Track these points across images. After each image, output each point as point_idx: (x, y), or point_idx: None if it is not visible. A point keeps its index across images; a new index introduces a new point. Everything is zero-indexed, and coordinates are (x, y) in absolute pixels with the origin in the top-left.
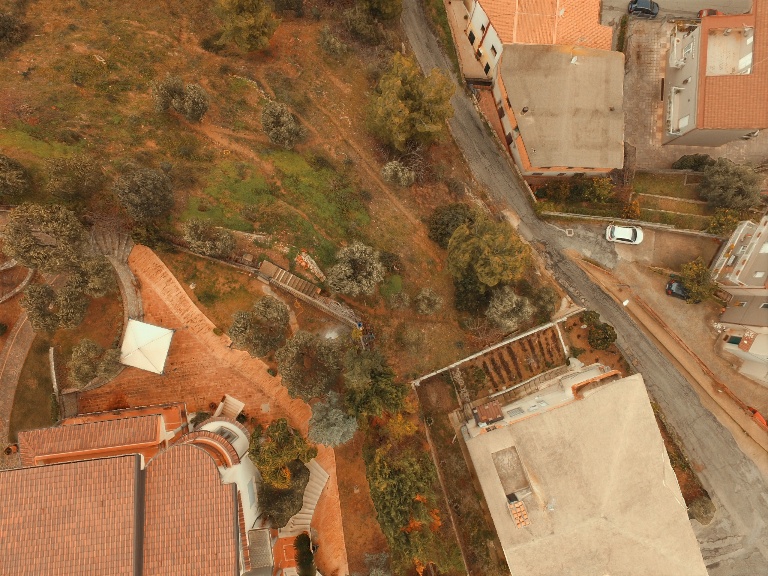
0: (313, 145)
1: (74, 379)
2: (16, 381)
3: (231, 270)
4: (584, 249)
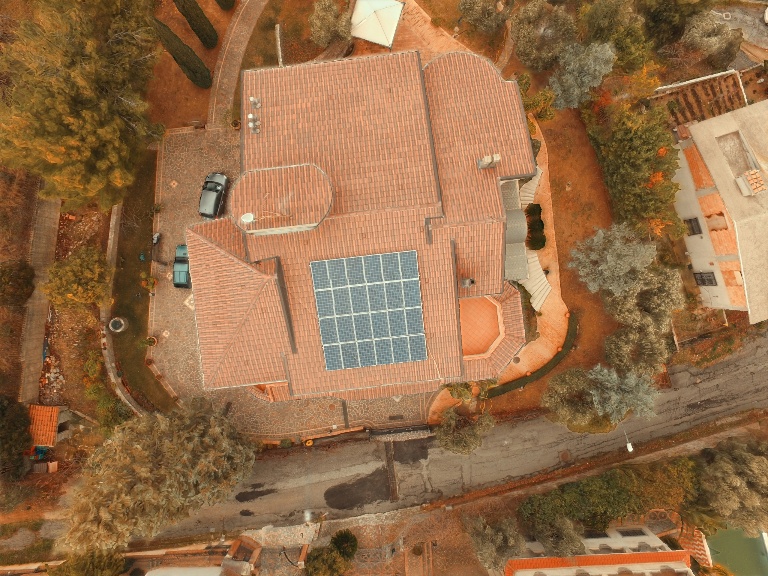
0: None
1: (317, 30)
2: (240, 58)
3: None
4: None
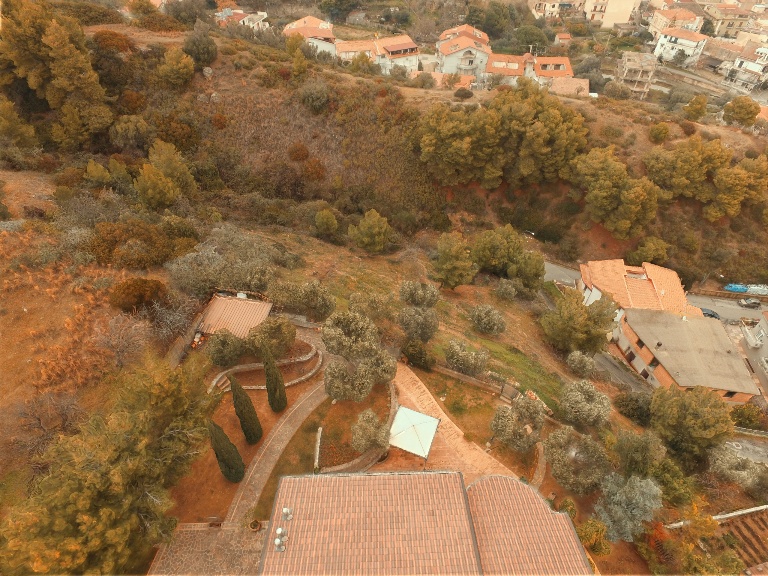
0: (504, 342)
1: (359, 439)
2: (278, 456)
3: (476, 389)
4: (759, 462)
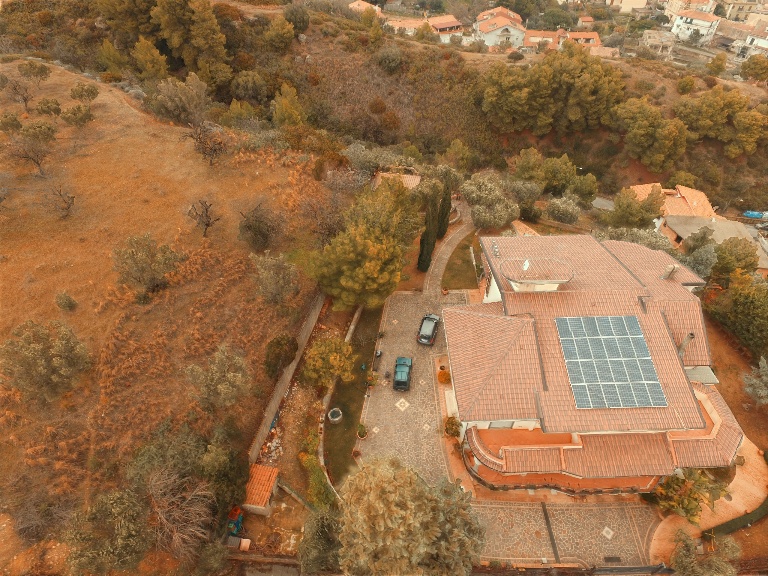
0: None
1: None
2: (447, 261)
3: (572, 233)
4: None
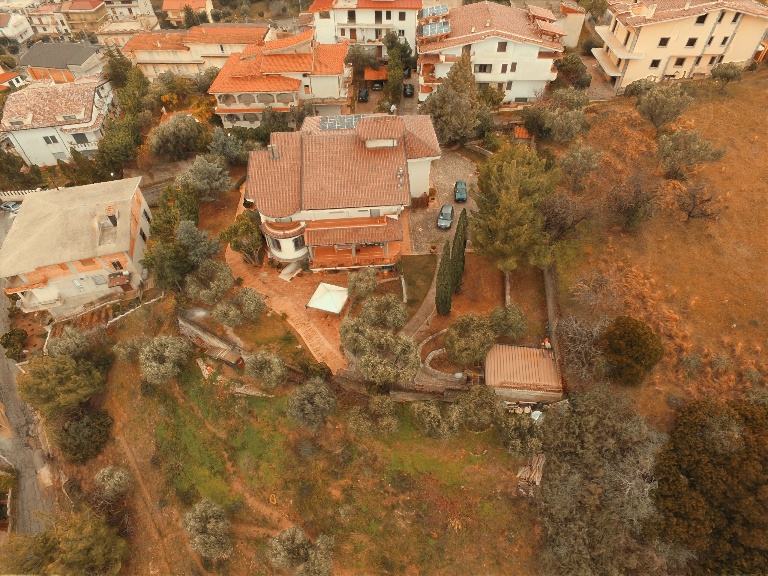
0: None
1: None
2: (433, 285)
3: None
4: None
